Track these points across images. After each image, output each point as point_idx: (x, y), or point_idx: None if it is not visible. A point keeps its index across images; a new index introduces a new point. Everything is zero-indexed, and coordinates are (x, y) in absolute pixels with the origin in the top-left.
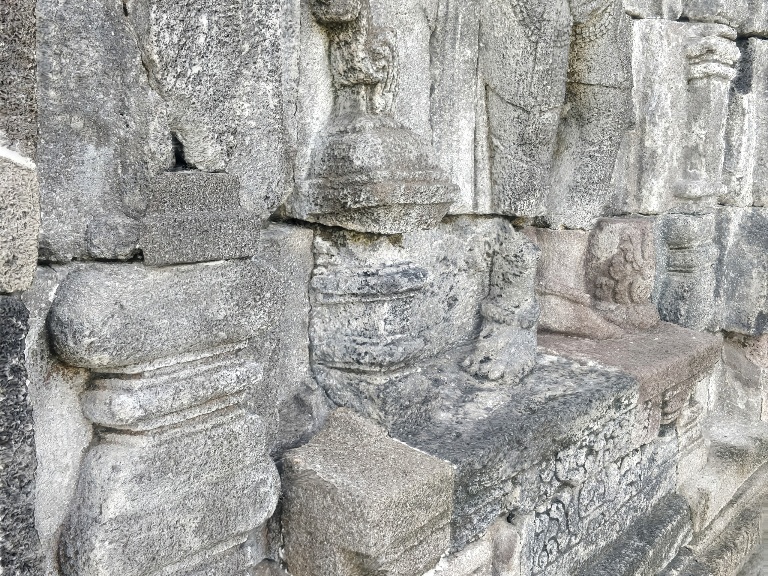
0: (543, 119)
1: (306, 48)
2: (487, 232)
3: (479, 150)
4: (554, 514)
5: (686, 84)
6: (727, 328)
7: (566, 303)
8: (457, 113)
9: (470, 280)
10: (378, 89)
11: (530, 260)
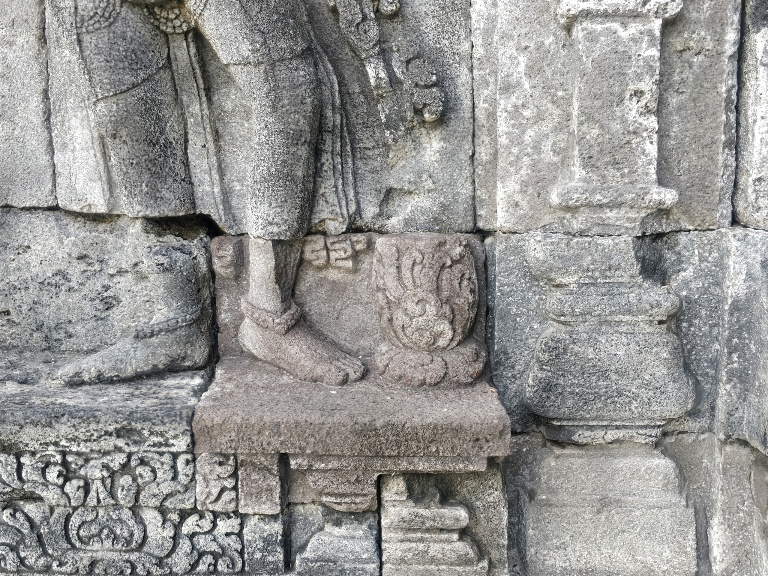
0: (98, 110)
1: None
2: None
3: None
4: (8, 520)
5: (567, 37)
6: (750, 440)
7: (255, 326)
8: (66, 113)
9: (142, 283)
10: None
11: (147, 264)
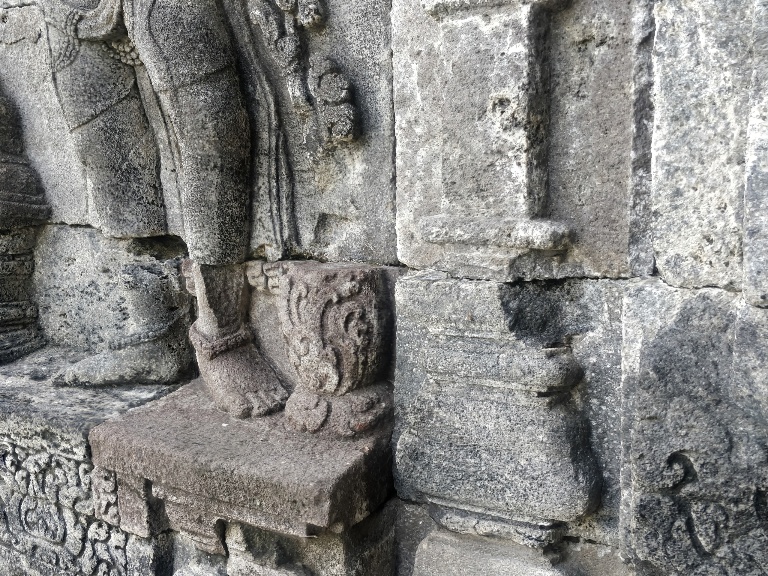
0: None
1: None
2: None
3: None
4: None
5: None
6: None
7: None
8: None
9: None
10: None
11: None
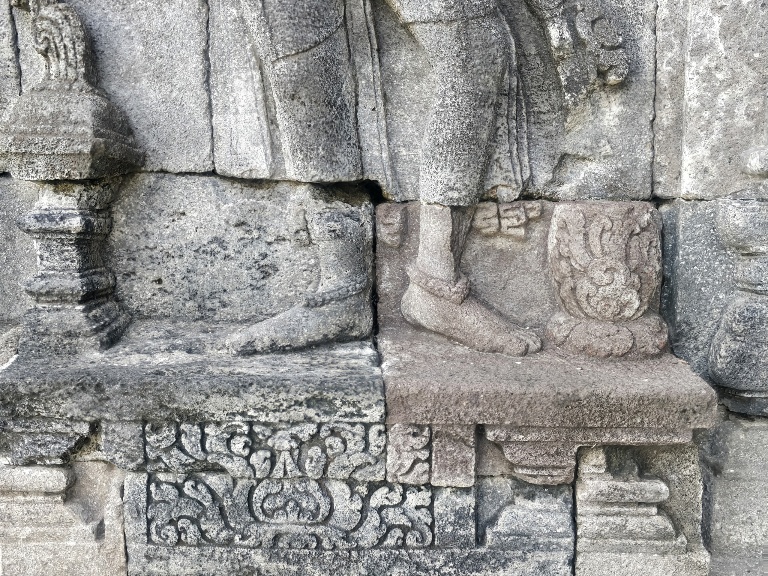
0: (276, 70)
1: (23, 33)
2: (302, 200)
3: (277, 111)
4: (189, 492)
5: None
6: None
7: (427, 295)
8: (229, 74)
9: (300, 252)
10: (50, 58)
11: (318, 231)
